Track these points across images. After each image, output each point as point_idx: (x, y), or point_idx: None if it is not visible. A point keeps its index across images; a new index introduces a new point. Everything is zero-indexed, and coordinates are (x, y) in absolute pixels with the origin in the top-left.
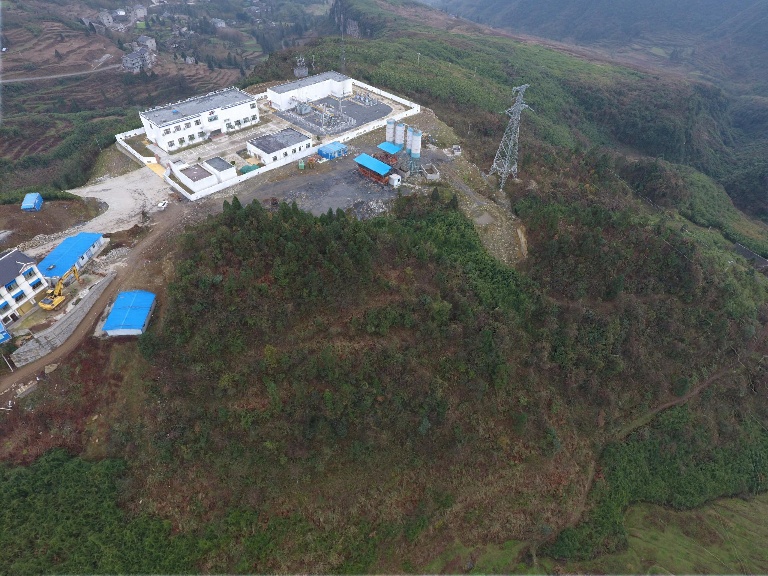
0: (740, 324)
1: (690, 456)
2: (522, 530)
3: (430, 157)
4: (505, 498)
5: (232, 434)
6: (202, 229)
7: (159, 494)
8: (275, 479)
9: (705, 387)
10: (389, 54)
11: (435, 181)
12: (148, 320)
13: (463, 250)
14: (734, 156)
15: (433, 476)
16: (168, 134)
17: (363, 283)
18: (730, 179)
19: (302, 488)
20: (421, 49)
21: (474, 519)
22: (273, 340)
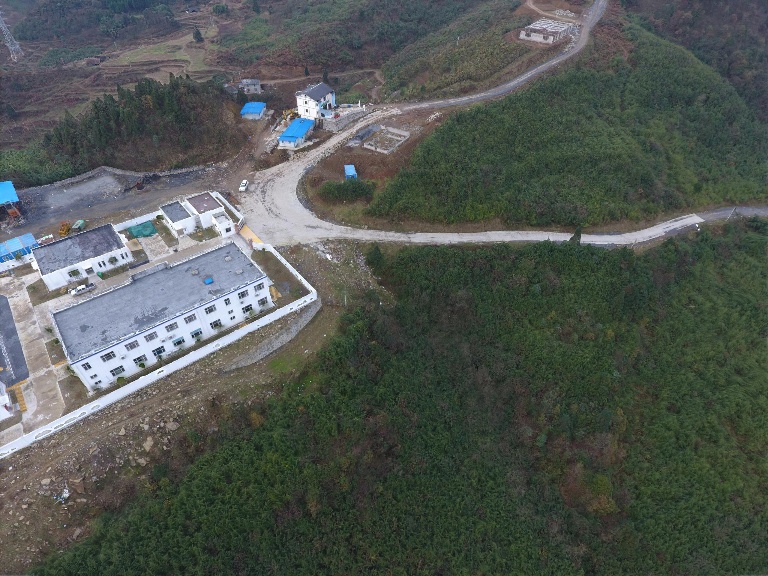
0: None
1: None
2: None
3: None
4: None
5: None
6: None
7: None
8: None
9: None
10: None
11: None
12: None
13: None
14: None
15: None
16: None
17: None
18: None
19: None
20: None
21: None
22: None
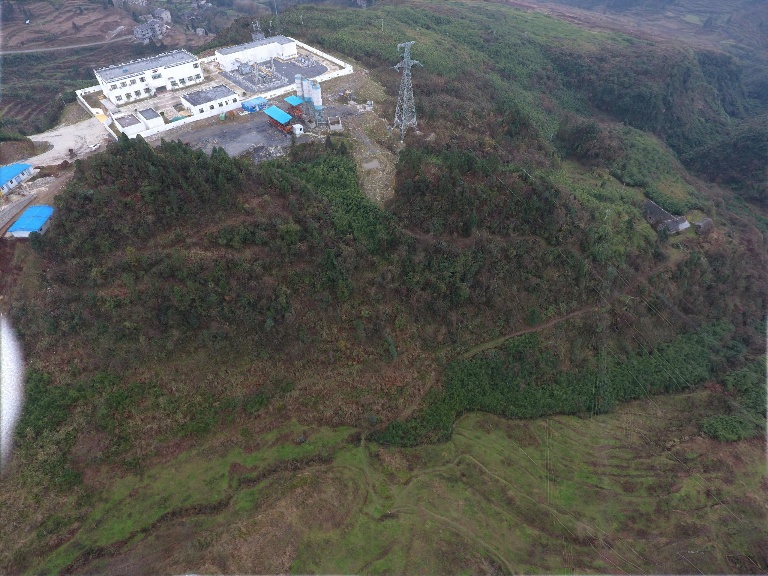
0: (607, 267)
1: (533, 377)
2: (354, 418)
3: (342, 111)
4: (341, 391)
5: (100, 315)
6: (93, 157)
7: (46, 357)
8: (135, 353)
9: (563, 321)
10: (357, 20)
11: (337, 131)
12: (47, 227)
13: (338, 188)
14: (734, 127)
15: (279, 368)
16: (115, 89)
17: (222, 205)
18: (706, 147)
19: (161, 364)
20: (400, 16)
21: (311, 404)
22: (137, 245)
